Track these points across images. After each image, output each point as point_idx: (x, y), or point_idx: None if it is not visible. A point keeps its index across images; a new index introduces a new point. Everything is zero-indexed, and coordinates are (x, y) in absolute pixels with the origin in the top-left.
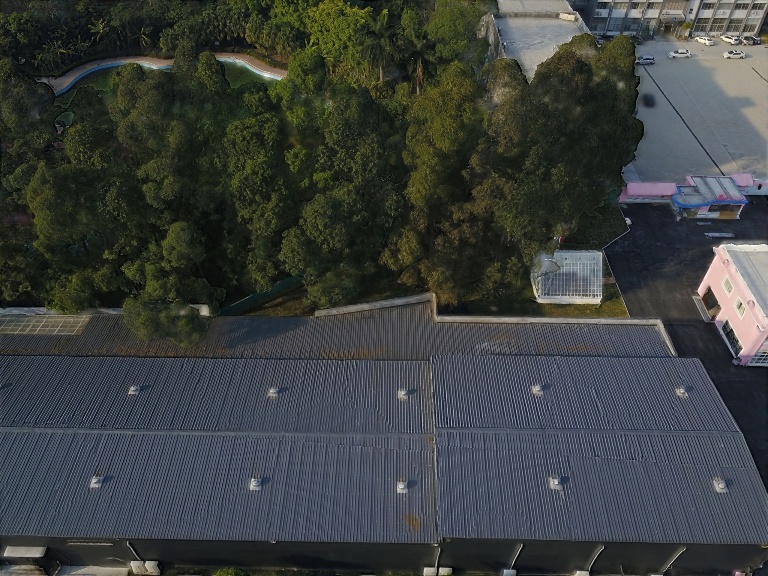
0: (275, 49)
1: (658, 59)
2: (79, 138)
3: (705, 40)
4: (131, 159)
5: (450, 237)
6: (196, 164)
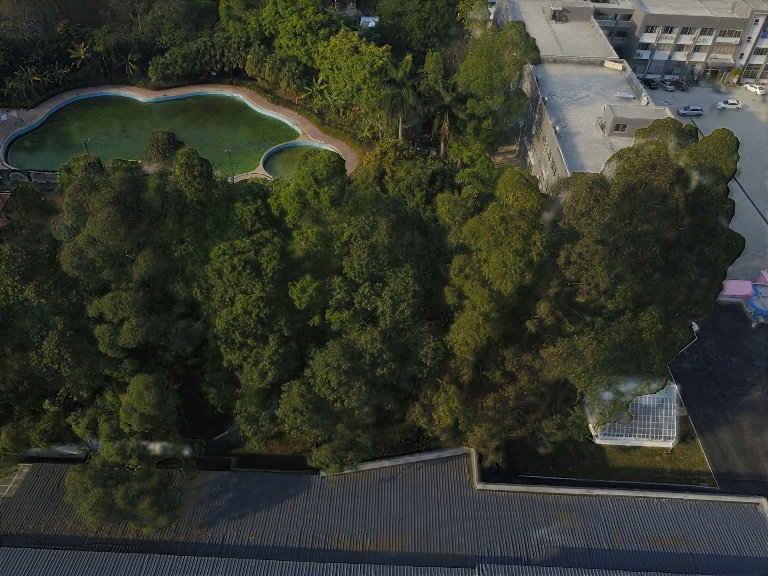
0: (278, 83)
1: (705, 109)
2: (6, 268)
3: (756, 88)
4: (82, 285)
5: (502, 394)
6: (170, 291)
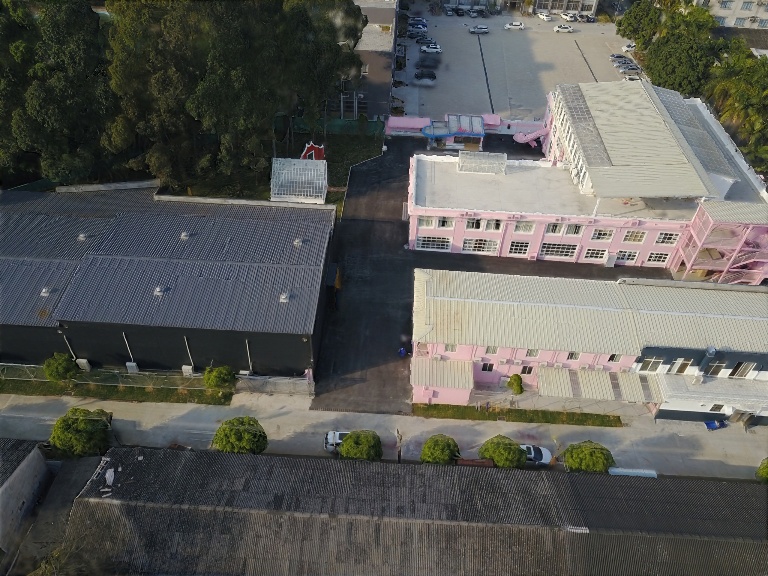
0: None
1: (494, 30)
2: None
3: (543, 16)
4: None
5: (152, 124)
6: None
